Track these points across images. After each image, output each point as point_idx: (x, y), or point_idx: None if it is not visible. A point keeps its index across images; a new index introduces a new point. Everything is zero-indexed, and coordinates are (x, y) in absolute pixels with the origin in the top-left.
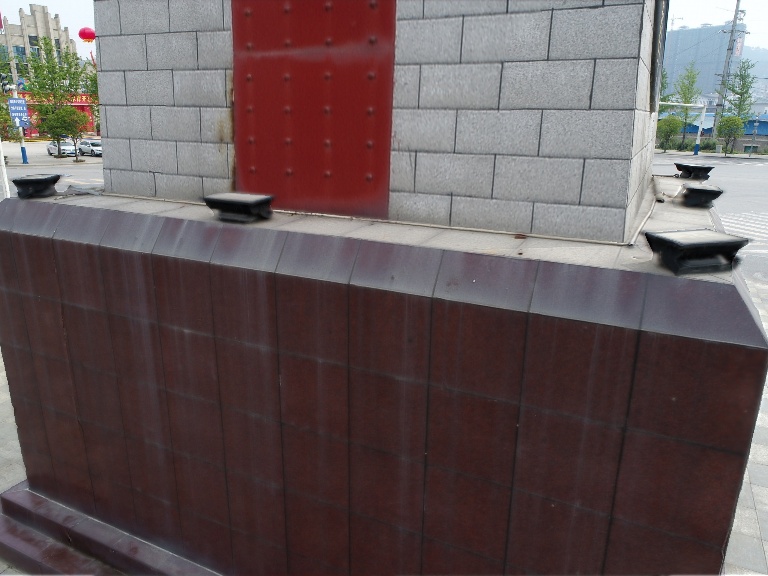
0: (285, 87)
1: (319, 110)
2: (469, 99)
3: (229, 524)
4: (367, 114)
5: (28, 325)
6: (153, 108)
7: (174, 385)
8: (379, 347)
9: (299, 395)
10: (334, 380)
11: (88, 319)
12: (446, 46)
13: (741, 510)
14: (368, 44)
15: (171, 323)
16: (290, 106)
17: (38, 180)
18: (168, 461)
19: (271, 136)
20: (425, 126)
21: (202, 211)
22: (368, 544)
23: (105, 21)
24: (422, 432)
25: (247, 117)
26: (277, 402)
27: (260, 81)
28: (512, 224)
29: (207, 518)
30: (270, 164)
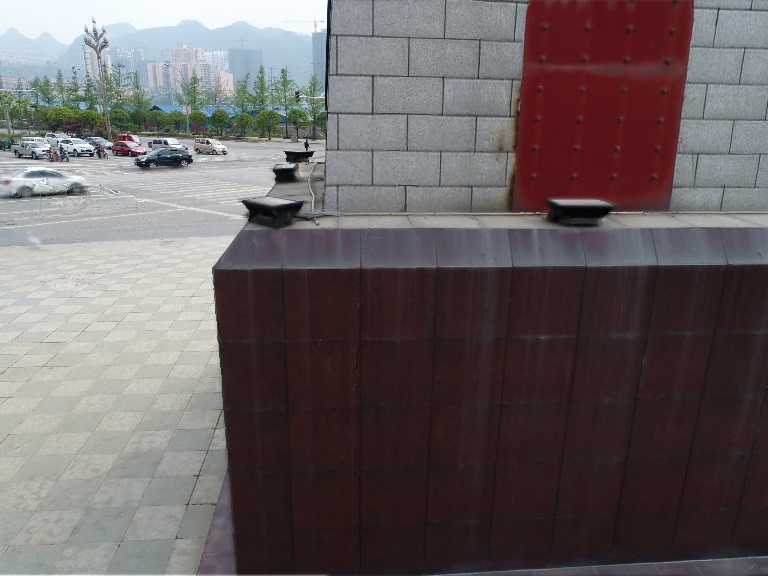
0: (580, 99)
1: (613, 120)
2: (744, 112)
3: (554, 515)
4: (658, 123)
5: (290, 379)
6: (412, 117)
7: (514, 396)
8: (744, 311)
9: (661, 369)
10: (698, 348)
11: (401, 352)
12: (729, 70)
13: None
14: (664, 64)
15: (524, 333)
16: (583, 116)
17: (299, 204)
18: (487, 477)
19: (559, 144)
20: (707, 133)
21: (510, 220)
22: (699, 478)
23: (349, 19)
24: (767, 371)
25: (534, 126)
26: (636, 381)
27: (552, 92)
28: (767, 205)
29: (526, 519)
30: (554, 170)
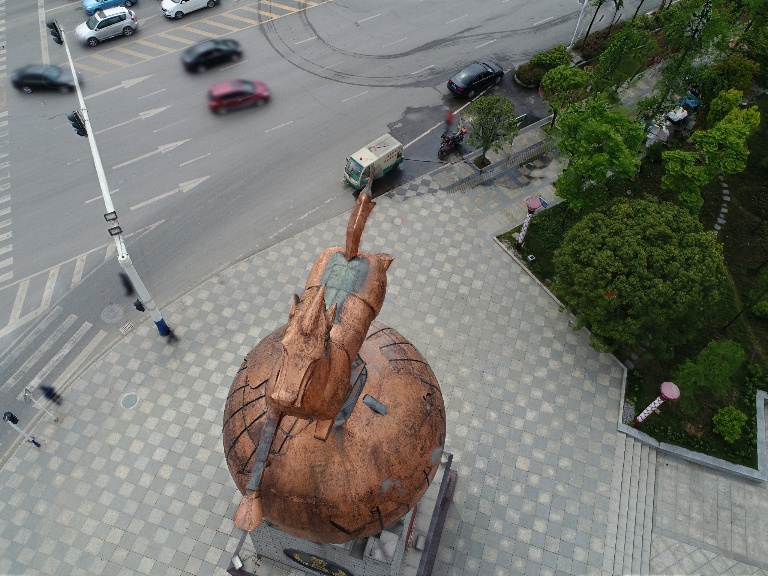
0: None
1: None
2: None
3: None
4: None
5: None
6: None
7: None
8: None
9: None
10: None
11: None
12: None
13: None
14: None
15: None
16: None
17: None
18: None
19: None
20: None
21: (413, 557)
22: None
23: None
24: None
25: None
26: None
27: None
28: None
29: None
30: None
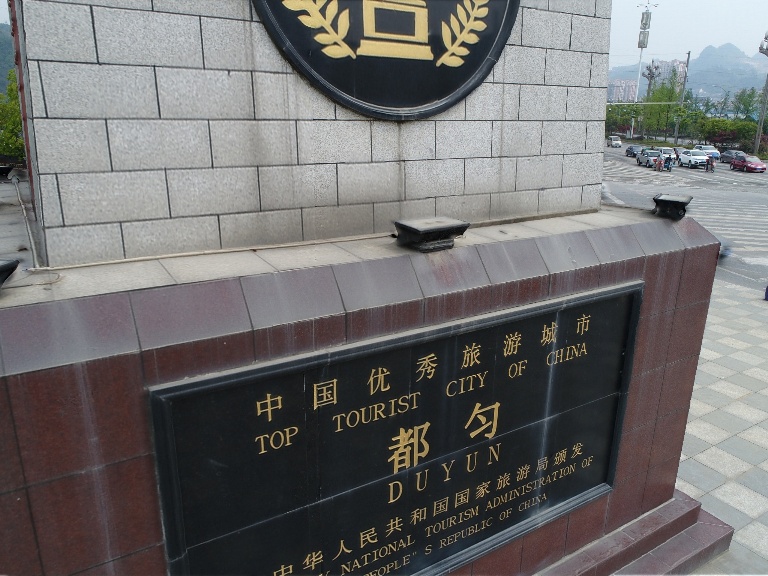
0: None
1: (24, 118)
2: None
3: None
4: None
5: None
6: None
7: None
8: None
9: None
10: None
11: None
12: None
13: None
14: None
15: None
16: None
17: None
18: None
19: None
20: None
21: None
22: None
23: None
24: None
25: None
26: None
27: None
28: None
29: None
30: None
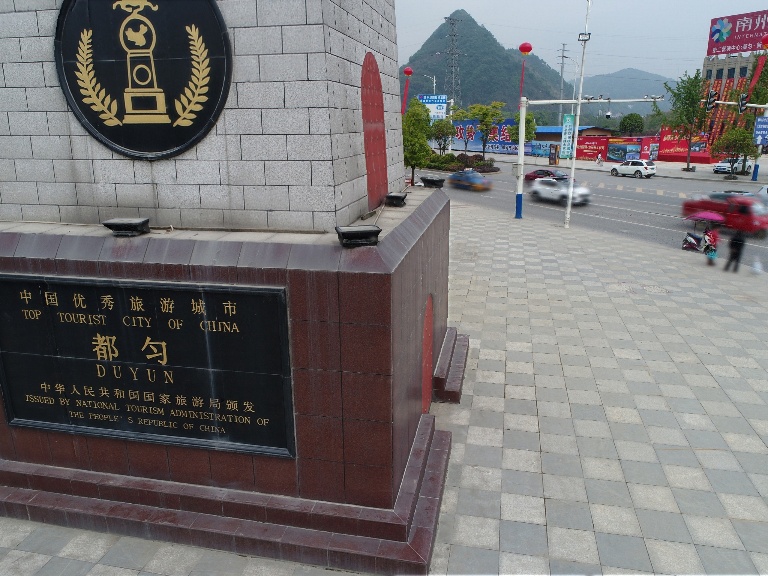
0: None
1: None
2: None
3: None
4: None
5: None
6: None
7: None
8: None
9: None
10: None
11: None
12: None
13: (185, 567)
14: None
15: None
16: None
17: None
18: None
19: None
20: None
21: None
22: None
23: None
24: None
25: None
26: None
27: None
28: None
29: None
30: None
